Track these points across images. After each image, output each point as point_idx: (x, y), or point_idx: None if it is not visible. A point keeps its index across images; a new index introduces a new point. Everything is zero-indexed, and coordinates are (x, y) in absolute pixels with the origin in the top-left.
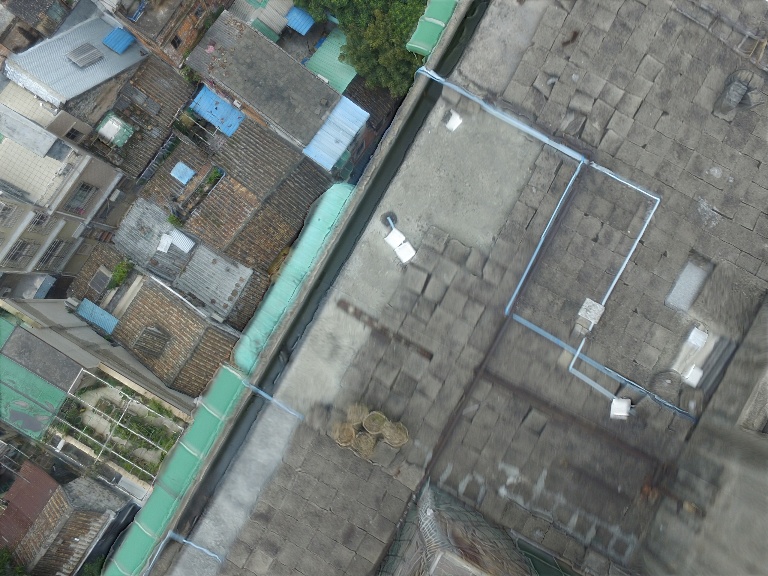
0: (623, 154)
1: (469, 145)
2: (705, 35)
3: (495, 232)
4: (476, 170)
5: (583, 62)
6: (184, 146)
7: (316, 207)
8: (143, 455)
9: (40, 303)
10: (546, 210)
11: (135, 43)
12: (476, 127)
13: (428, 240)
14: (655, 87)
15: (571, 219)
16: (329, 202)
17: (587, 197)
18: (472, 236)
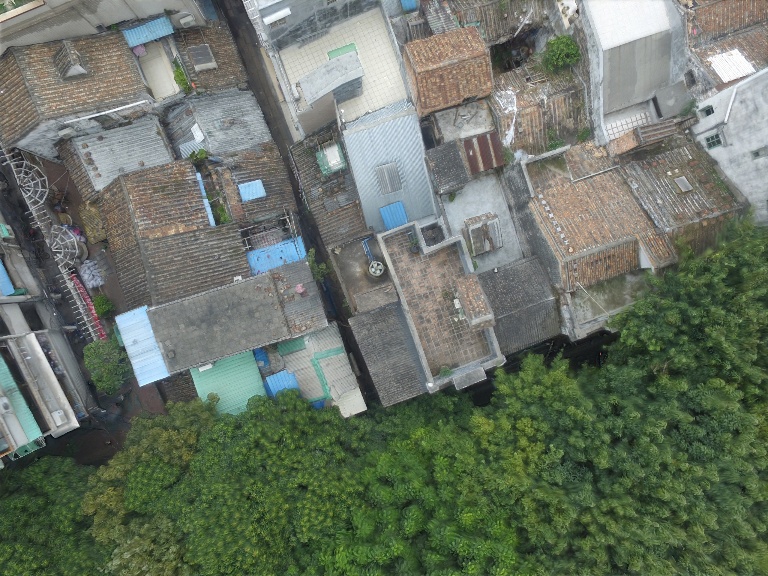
0: None
1: None
2: None
3: None
4: None
5: None
6: None
7: None
8: None
9: None
10: None
11: None
12: None
13: None
14: None
15: None
16: None
17: None
18: None
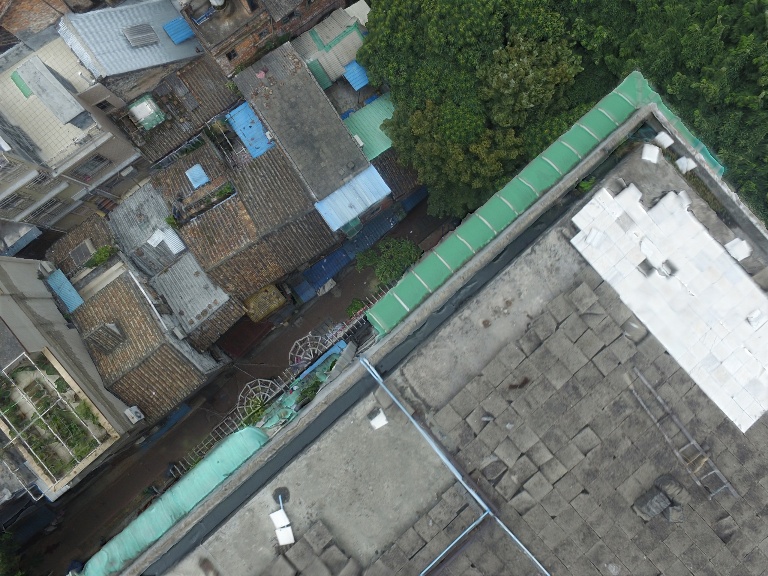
0: (530, 518)
1: (386, 448)
2: (652, 426)
3: (380, 547)
4: (384, 476)
5: (524, 411)
6: (209, 148)
7: (220, 447)
8: (57, 448)
9: (12, 263)
10: (435, 548)
11: (195, 37)
12: (399, 433)
13: (309, 537)
14: (585, 461)
15: (457, 565)
16: (234, 448)
17: (480, 548)
18: (357, 541)
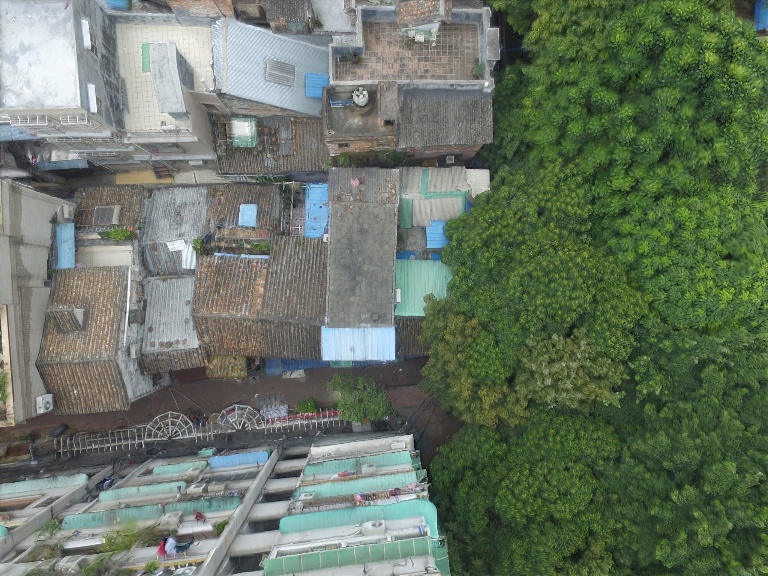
0: None
1: None
2: None
3: None
4: None
5: None
6: None
7: None
8: None
9: (35, 199)
10: None
11: None
12: None
13: None
14: None
15: None
16: None
17: None
18: None
